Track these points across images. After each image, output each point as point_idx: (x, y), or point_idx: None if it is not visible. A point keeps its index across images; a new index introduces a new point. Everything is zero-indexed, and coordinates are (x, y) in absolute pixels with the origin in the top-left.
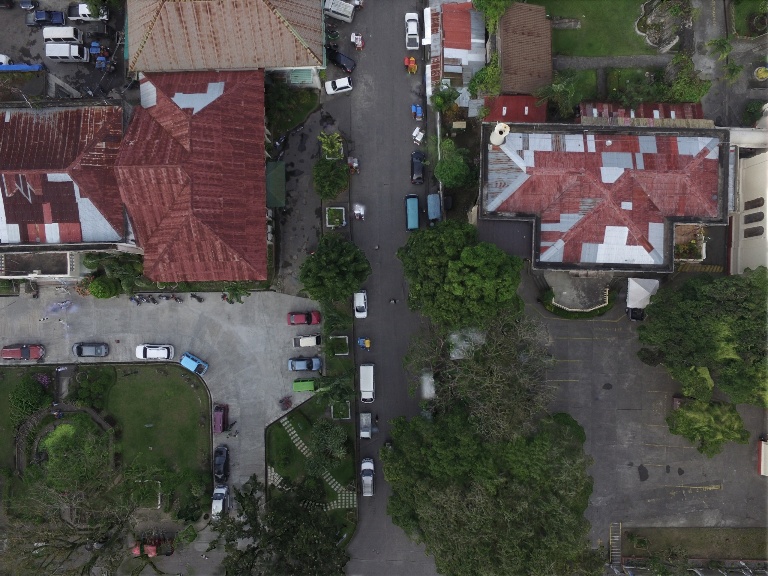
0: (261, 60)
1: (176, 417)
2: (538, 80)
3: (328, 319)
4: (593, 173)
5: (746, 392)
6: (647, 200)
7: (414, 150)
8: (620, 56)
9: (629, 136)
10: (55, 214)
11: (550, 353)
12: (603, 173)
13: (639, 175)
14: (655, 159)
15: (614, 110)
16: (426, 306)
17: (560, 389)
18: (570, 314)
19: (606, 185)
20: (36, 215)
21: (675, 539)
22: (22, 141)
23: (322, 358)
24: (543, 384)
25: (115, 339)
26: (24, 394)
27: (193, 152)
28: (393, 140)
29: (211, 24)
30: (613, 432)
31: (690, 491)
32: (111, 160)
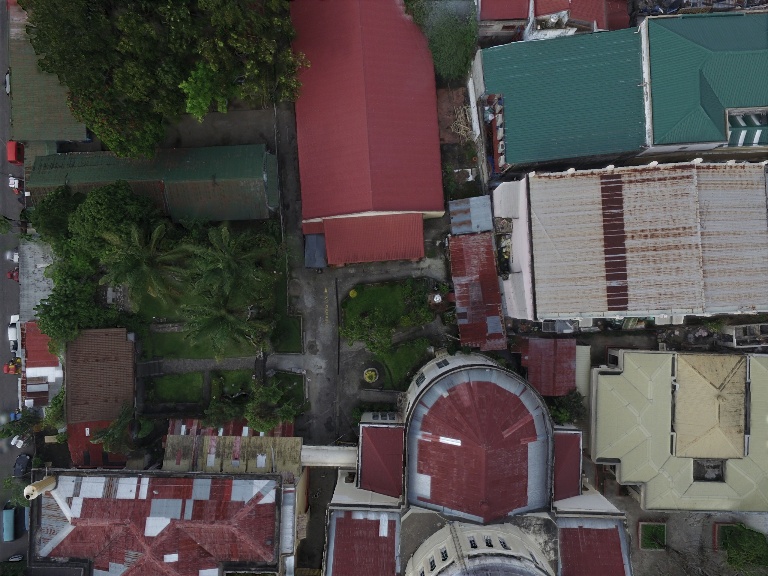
0: None
1: None
2: (115, 405)
3: None
4: (137, 525)
5: None
6: (197, 548)
7: (23, 451)
8: (227, 358)
9: (184, 479)
10: None
11: None
12: (148, 524)
13: (185, 526)
14: (205, 507)
15: (203, 427)
16: None
17: None
18: None
19: (147, 539)
20: None
21: None
22: None
23: None
24: None
25: None
26: None
27: None
28: (2, 441)
29: None
30: None
31: None
32: None
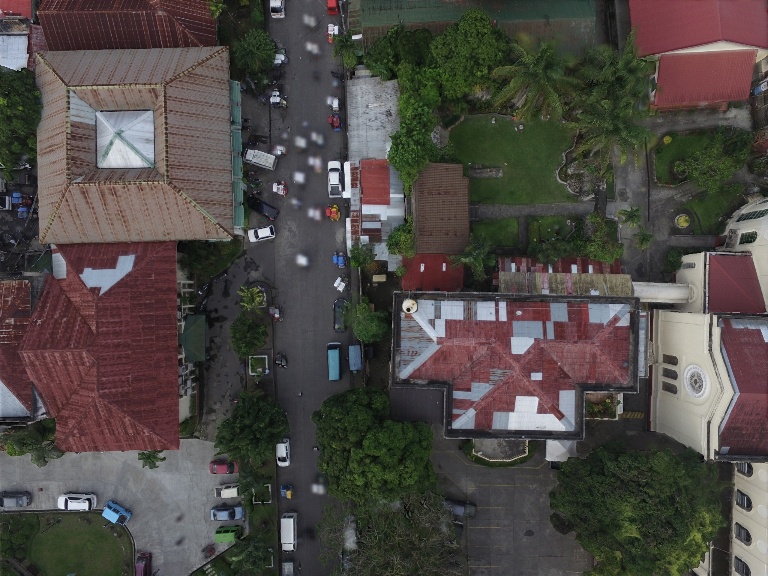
0: (171, 234)
1: (99, 565)
2: (455, 239)
3: (242, 485)
4: (503, 344)
5: (648, 574)
6: (558, 368)
7: (337, 297)
8: (542, 204)
9: (541, 303)
10: None
11: (472, 500)
12: (513, 344)
13: (549, 345)
14: (565, 328)
15: (532, 265)
16: (331, 489)
17: (482, 536)
18: (491, 463)
19: (515, 357)
20: None
21: None
22: None
23: None
24: (446, 568)
25: (38, 487)
26: None
27: (99, 334)
28: (316, 287)
29: (118, 204)
30: None
31: None
32: (20, 336)
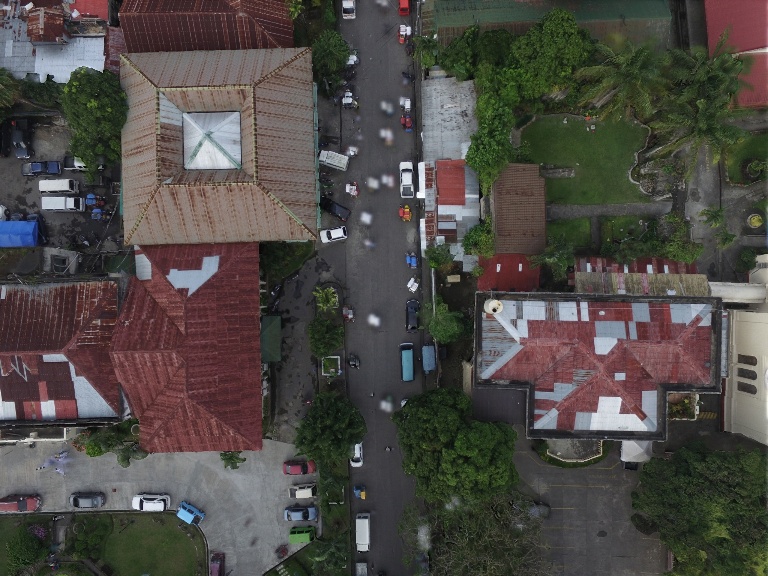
0: (256, 235)
1: (173, 565)
2: (532, 239)
3: (323, 486)
4: (586, 344)
5: (738, 575)
6: (640, 369)
7: (409, 297)
8: (614, 204)
9: (622, 303)
10: (51, 392)
11: (545, 501)
12: (596, 344)
13: (632, 345)
14: (648, 328)
15: (608, 265)
16: (420, 489)
17: (555, 536)
18: (564, 464)
19: (599, 357)
20: (32, 393)
21: None
22: (18, 320)
23: (318, 506)
24: (537, 569)
25: (112, 488)
26: (21, 551)
27: (188, 335)
28: (388, 287)
29: (206, 206)
30: None
31: None
32: (106, 337)
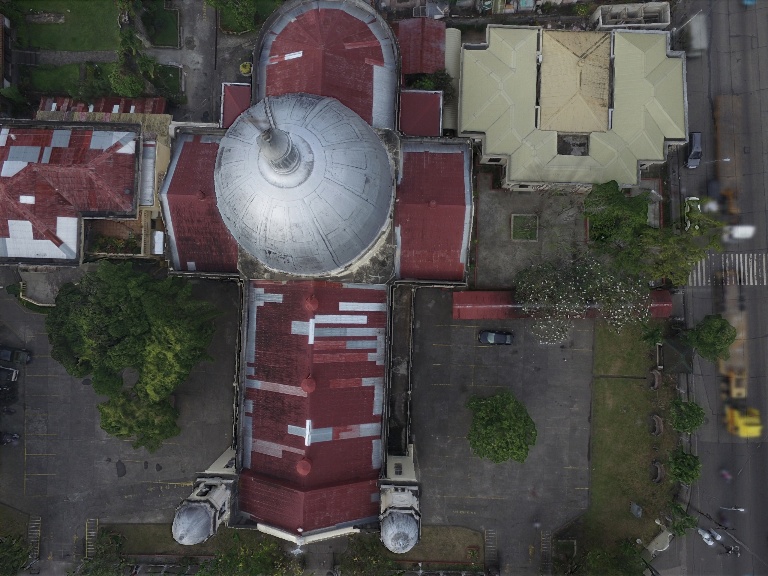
0: None
1: None
2: None
3: None
4: None
5: (100, 387)
6: (55, 194)
7: None
8: (104, 51)
9: (44, 130)
10: None
11: (29, 348)
12: (5, 167)
13: (42, 169)
14: (63, 153)
15: (74, 104)
16: None
17: (39, 384)
18: (42, 309)
19: (3, 179)
20: None
21: (152, 535)
22: None
23: None
24: None
25: None
26: None
27: None
28: None
29: None
30: (91, 428)
31: (168, 487)
32: None
